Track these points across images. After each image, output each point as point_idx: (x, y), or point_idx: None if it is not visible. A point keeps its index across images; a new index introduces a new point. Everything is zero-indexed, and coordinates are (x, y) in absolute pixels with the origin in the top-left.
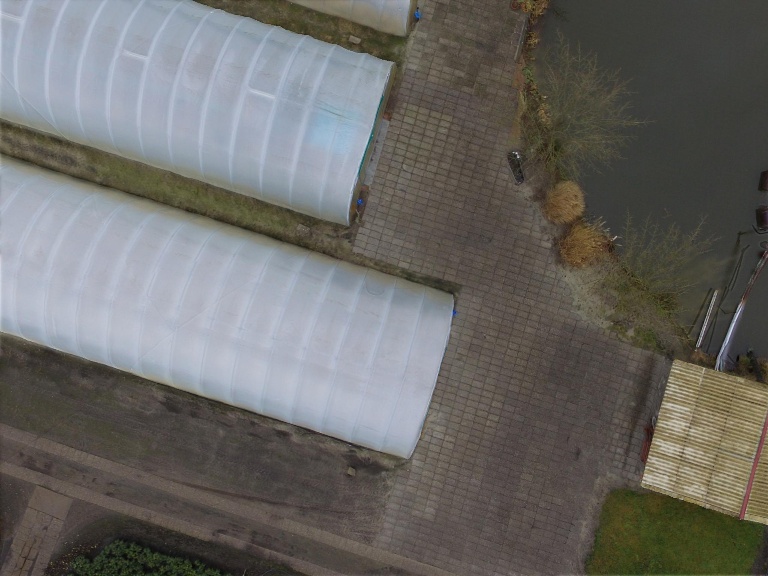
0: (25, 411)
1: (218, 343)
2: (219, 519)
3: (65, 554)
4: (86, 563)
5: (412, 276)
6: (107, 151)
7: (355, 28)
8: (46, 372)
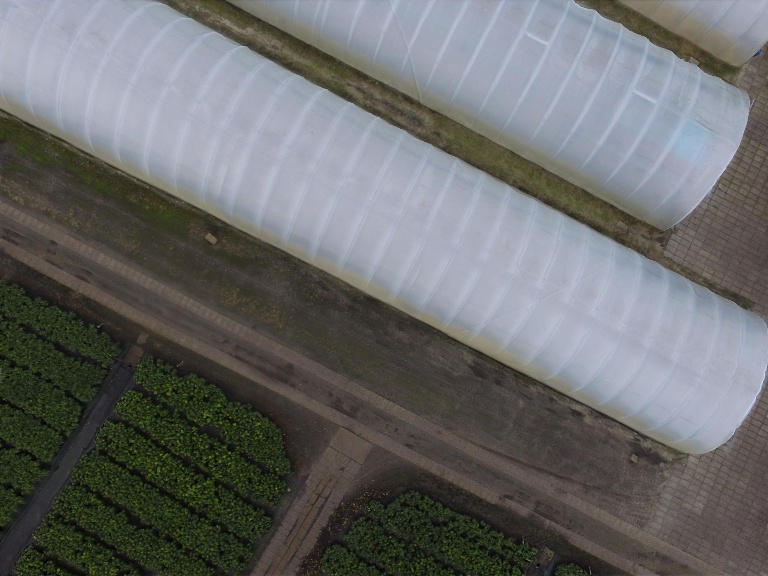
0: (340, 354)
1: (572, 319)
2: (507, 485)
3: (357, 497)
4: (380, 508)
5: (712, 287)
6: (456, 121)
7: (696, 51)
8: (365, 320)
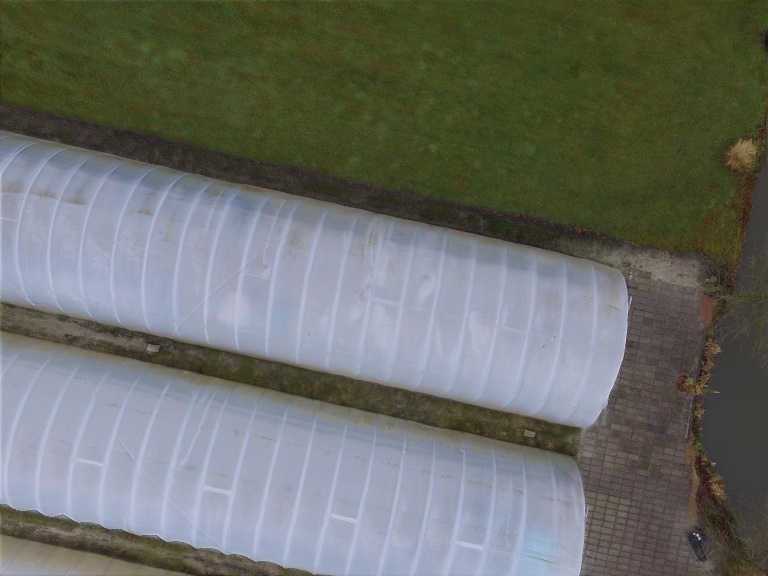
0: None
1: None
2: None
3: None
4: None
5: None
6: None
7: (529, 422)
8: None
